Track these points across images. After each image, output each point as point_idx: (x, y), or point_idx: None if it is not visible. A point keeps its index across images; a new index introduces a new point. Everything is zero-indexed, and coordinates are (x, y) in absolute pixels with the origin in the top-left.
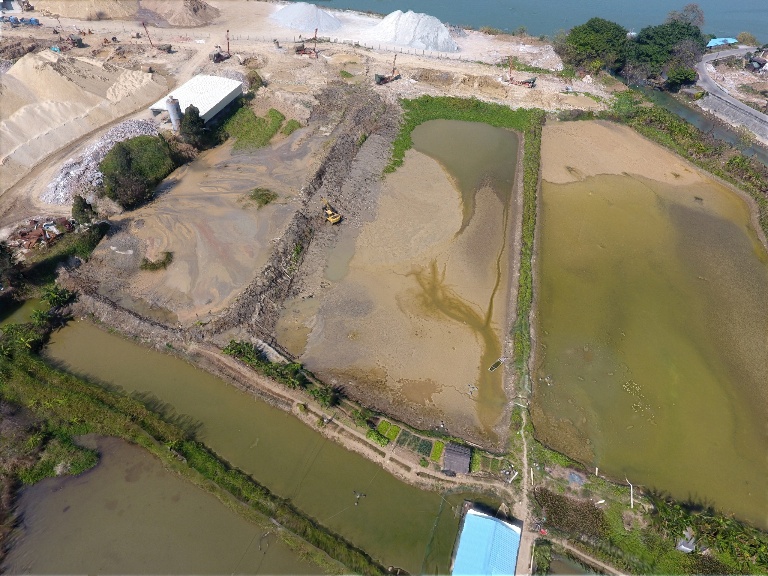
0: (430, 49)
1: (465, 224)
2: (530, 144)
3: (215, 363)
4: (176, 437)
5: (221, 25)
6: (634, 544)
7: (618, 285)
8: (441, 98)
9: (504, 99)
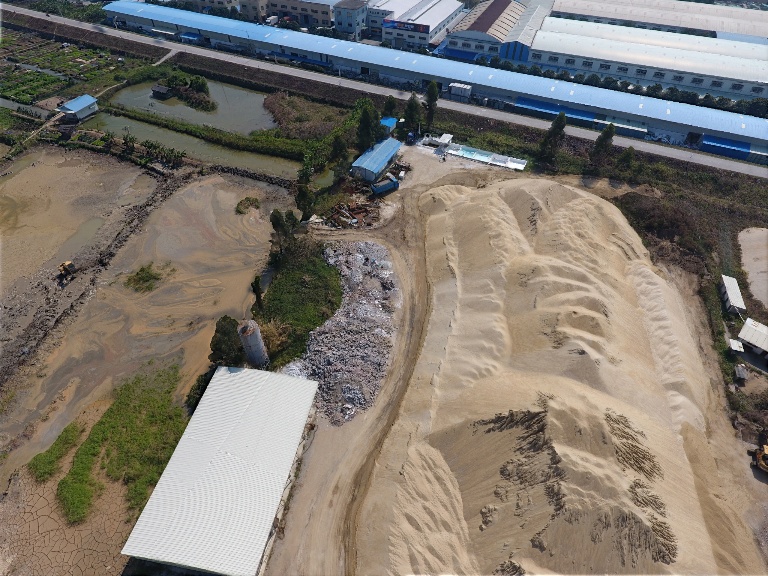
0: None
1: None
2: None
3: (194, 159)
4: (209, 131)
5: None
6: (5, 122)
7: None
8: None
9: None
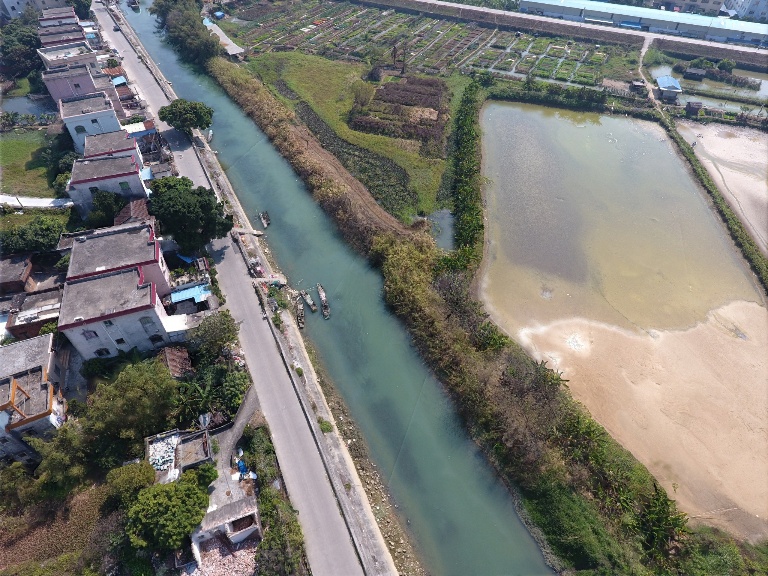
0: None
1: None
2: None
3: None
4: None
5: None
6: None
7: (632, 190)
8: None
9: None
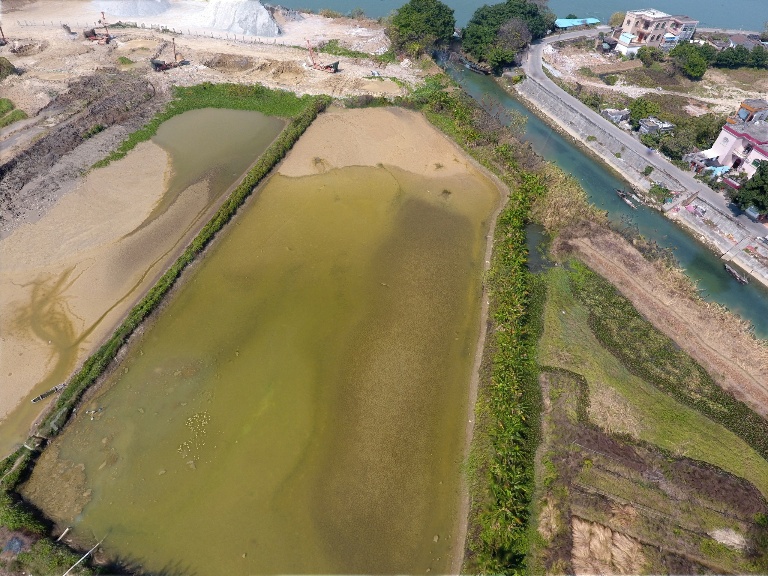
0: (248, 33)
1: (144, 224)
2: (283, 133)
3: None
4: None
5: (28, 11)
6: None
7: (276, 294)
8: (222, 85)
9: (293, 85)
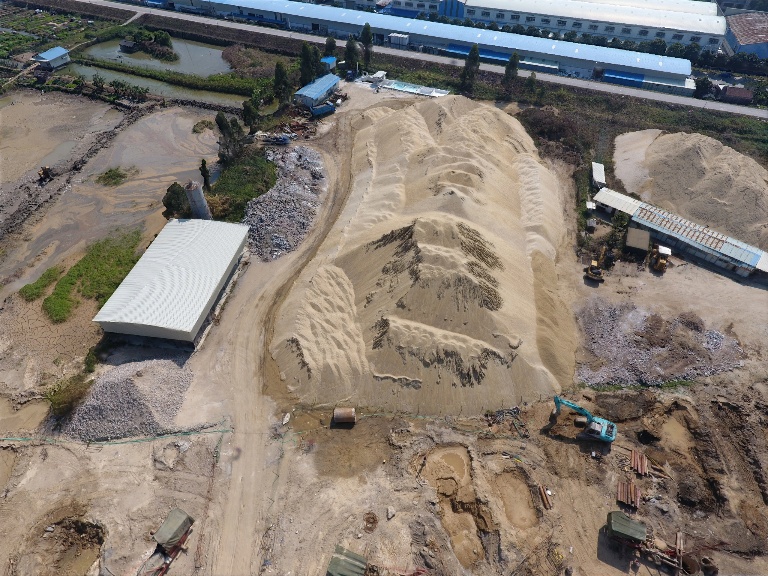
0: None
1: None
2: None
3: None
4: (171, 74)
5: None
6: None
7: None
8: None
9: None
